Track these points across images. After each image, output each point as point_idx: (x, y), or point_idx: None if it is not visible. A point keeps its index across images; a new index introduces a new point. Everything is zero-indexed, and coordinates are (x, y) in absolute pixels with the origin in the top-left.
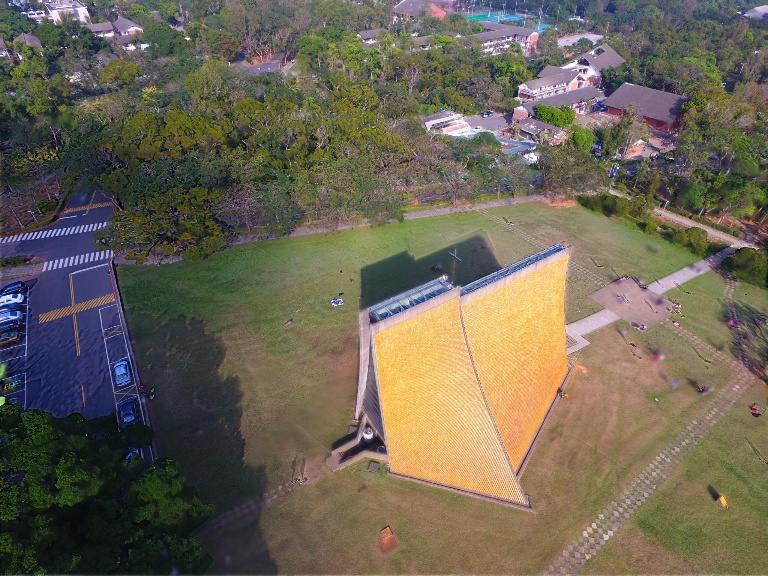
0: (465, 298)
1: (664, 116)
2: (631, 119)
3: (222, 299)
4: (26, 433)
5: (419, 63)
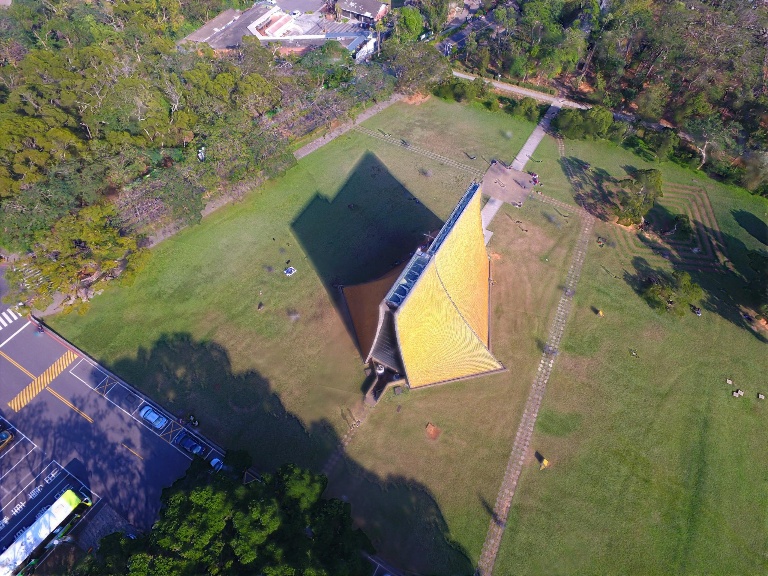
0: None
1: None
2: None
3: (184, 310)
4: (205, 507)
5: None
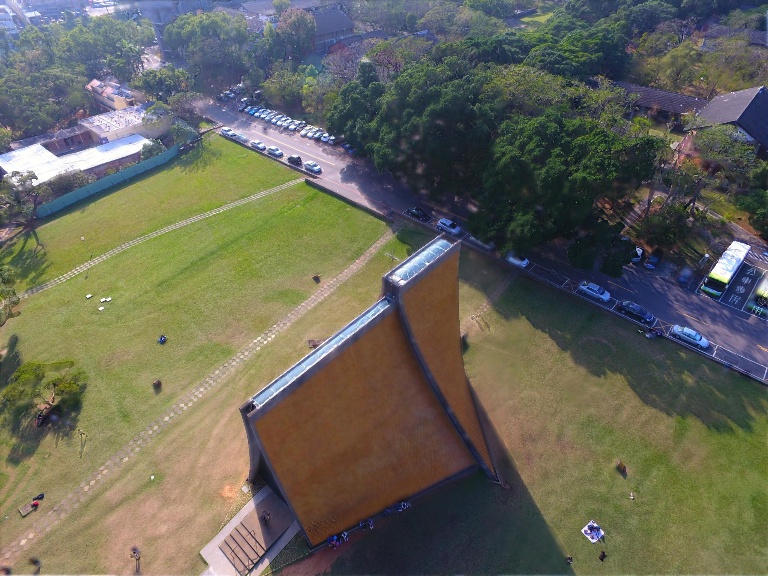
0: None
1: None
2: None
3: (747, 478)
4: None
5: None
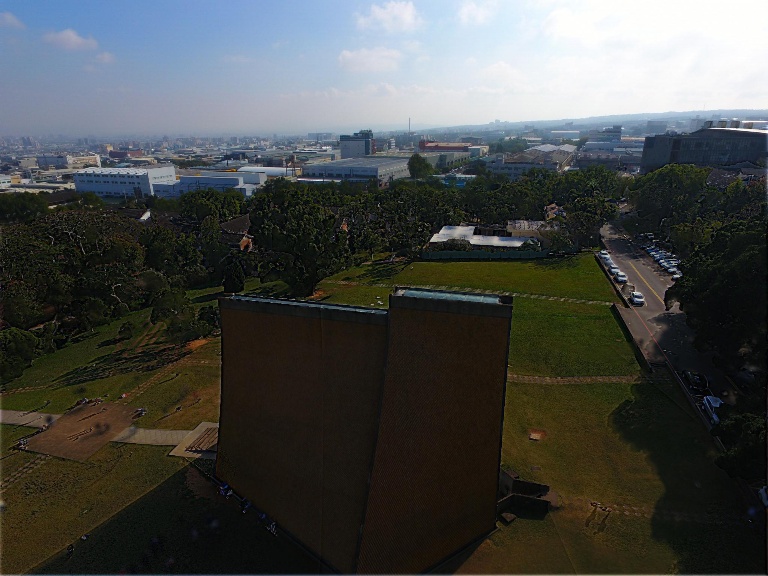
0: None
1: None
2: None
3: None
4: None
5: None
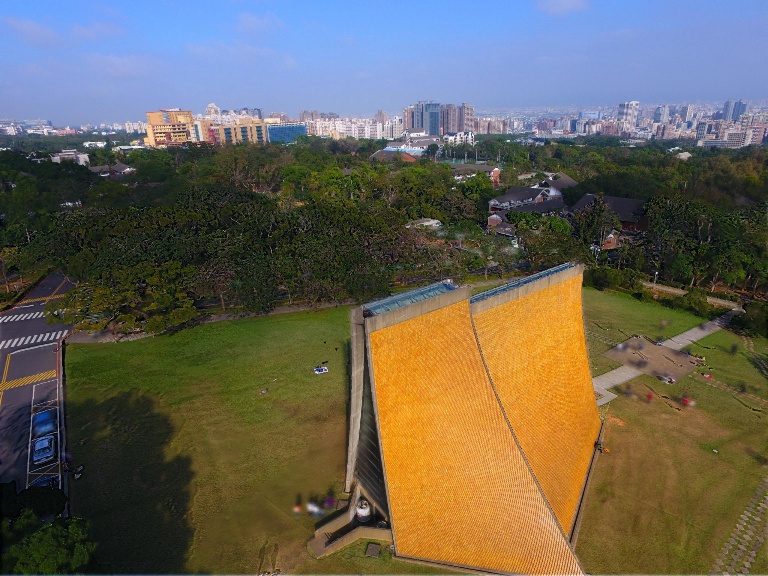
0: (475, 307)
1: (629, 217)
2: (602, 207)
3: (186, 372)
4: None
5: (396, 185)
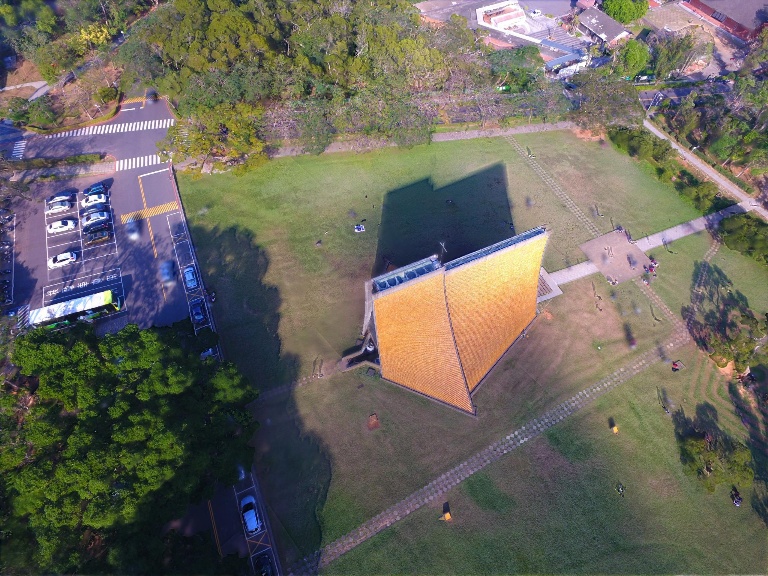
0: (450, 271)
1: (748, 20)
2: (692, 43)
3: (264, 215)
4: (145, 346)
5: None
